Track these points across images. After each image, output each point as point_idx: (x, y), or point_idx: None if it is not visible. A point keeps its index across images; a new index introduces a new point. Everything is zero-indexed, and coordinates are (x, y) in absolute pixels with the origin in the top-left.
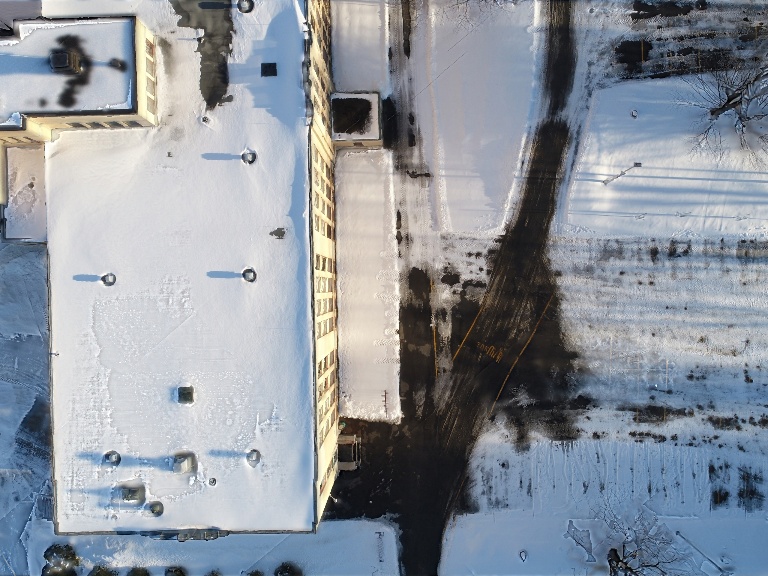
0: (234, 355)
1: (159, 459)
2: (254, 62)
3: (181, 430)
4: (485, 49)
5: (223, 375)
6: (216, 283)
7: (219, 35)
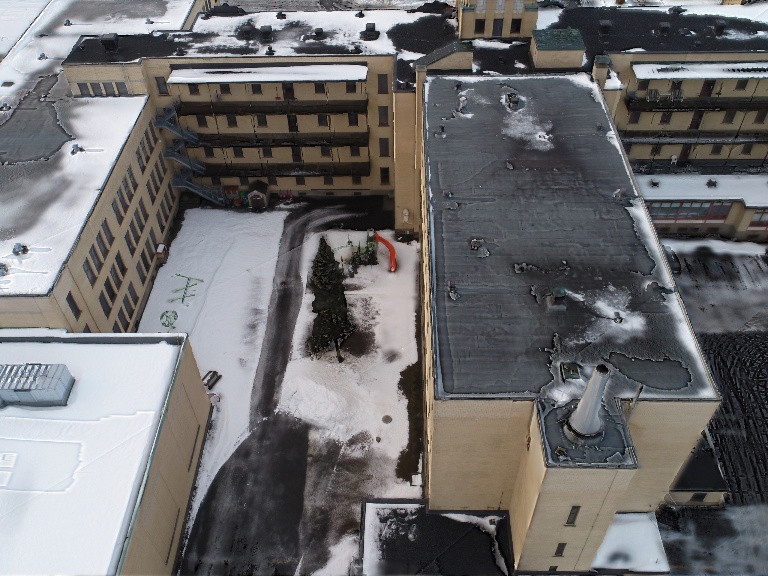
0: (94, 5)
1: None
2: (16, 89)
3: None
4: None
5: (103, 0)
6: (90, 22)
7: (32, 98)
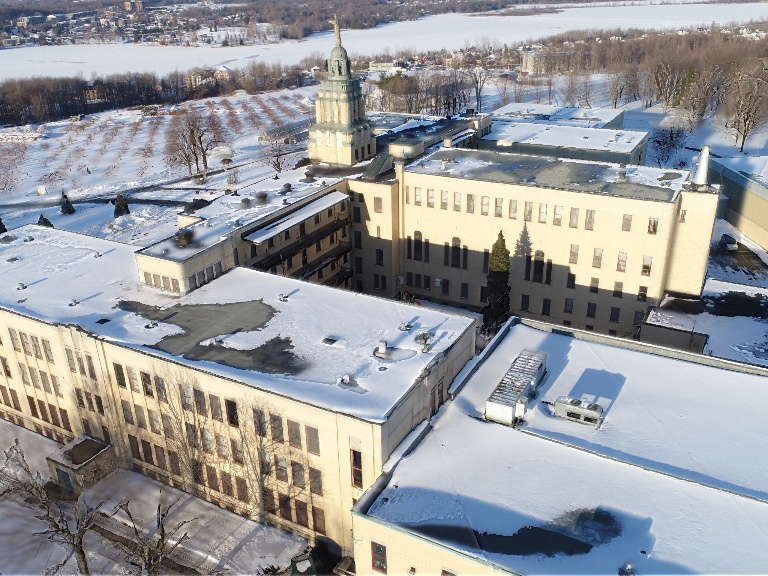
0: (1, 275)
1: (5, 249)
2: None
3: (4, 256)
4: (17, 572)
5: None
6: None
7: None
